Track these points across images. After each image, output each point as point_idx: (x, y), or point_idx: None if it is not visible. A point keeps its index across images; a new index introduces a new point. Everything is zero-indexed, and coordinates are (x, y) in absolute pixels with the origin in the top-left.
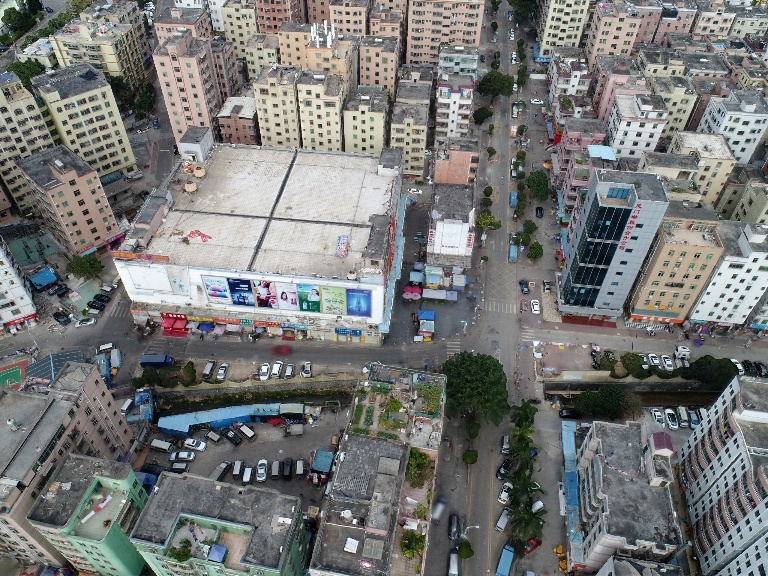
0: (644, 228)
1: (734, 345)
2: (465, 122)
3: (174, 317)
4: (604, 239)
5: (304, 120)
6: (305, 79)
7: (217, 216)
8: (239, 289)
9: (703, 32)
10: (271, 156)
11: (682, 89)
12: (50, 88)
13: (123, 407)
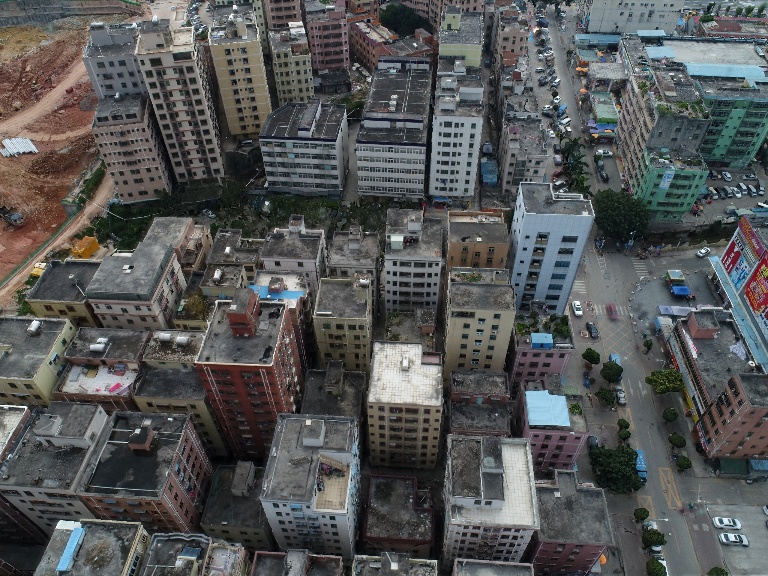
0: None
1: None
2: None
3: None
4: None
5: None
6: None
7: None
8: None
9: None
10: None
11: (392, 554)
12: None
13: None
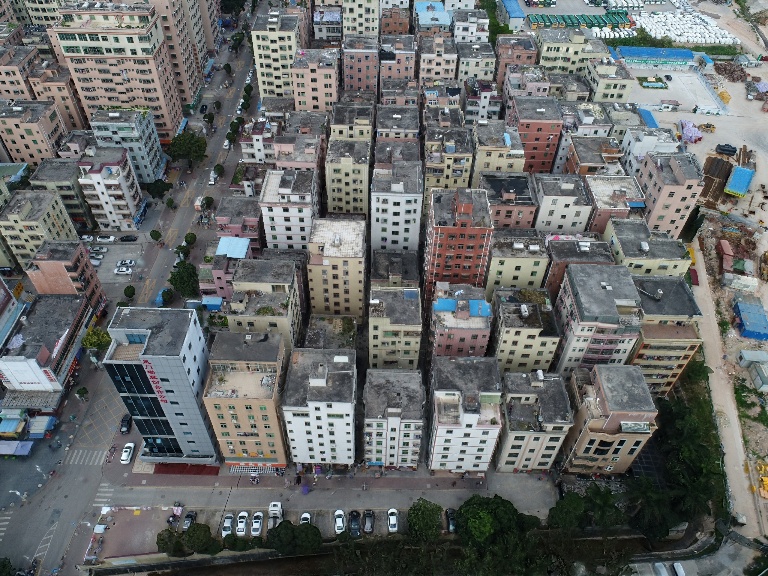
0: (172, 382)
1: (350, 487)
2: (122, 203)
3: None
4: (138, 393)
5: None
6: None
7: None
8: None
9: (428, 74)
10: None
11: (348, 159)
12: None
13: None
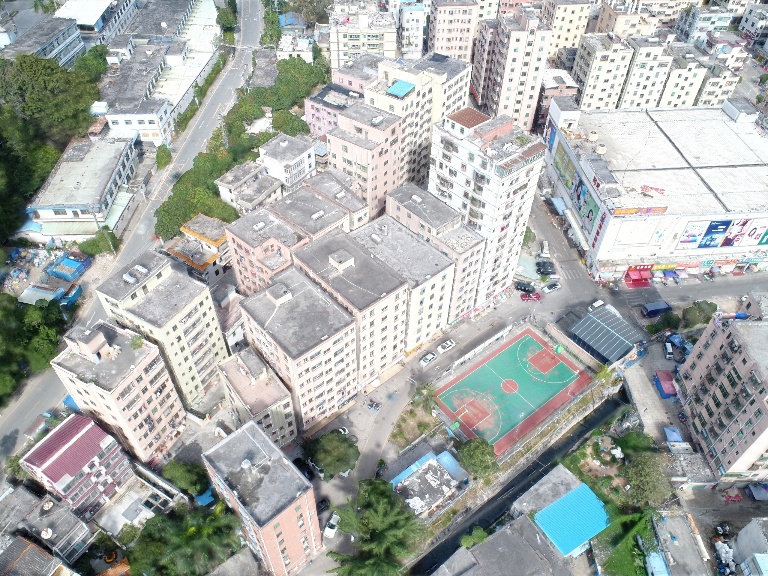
0: None
1: None
2: None
3: (640, 269)
4: None
5: (632, 83)
6: (638, 43)
7: (646, 172)
8: (714, 231)
9: None
10: (628, 117)
11: None
12: (436, 70)
13: (669, 350)
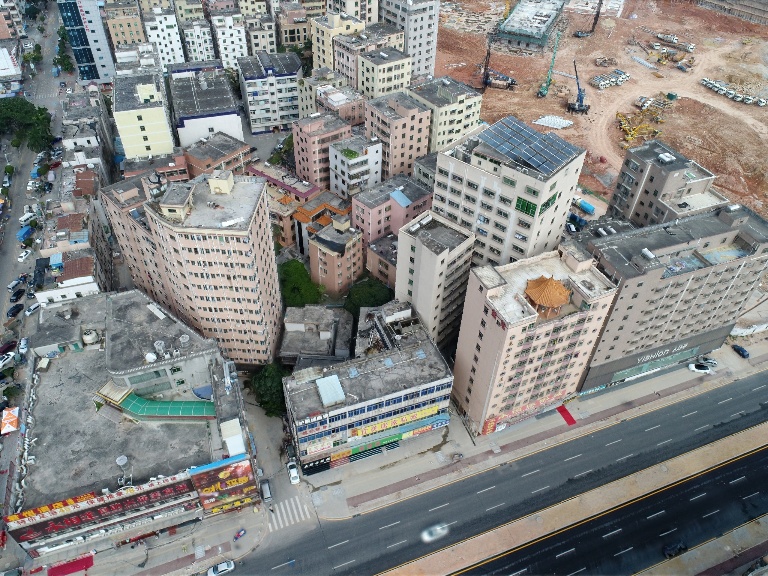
0: (91, 13)
1: None
2: (14, 13)
3: None
4: (74, 26)
5: None
6: None
7: None
8: None
9: None
10: None
11: None
12: None
13: None
